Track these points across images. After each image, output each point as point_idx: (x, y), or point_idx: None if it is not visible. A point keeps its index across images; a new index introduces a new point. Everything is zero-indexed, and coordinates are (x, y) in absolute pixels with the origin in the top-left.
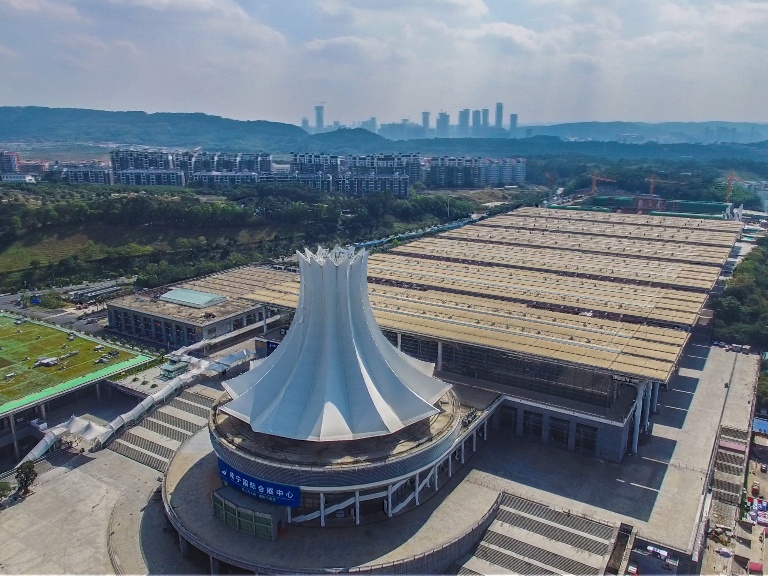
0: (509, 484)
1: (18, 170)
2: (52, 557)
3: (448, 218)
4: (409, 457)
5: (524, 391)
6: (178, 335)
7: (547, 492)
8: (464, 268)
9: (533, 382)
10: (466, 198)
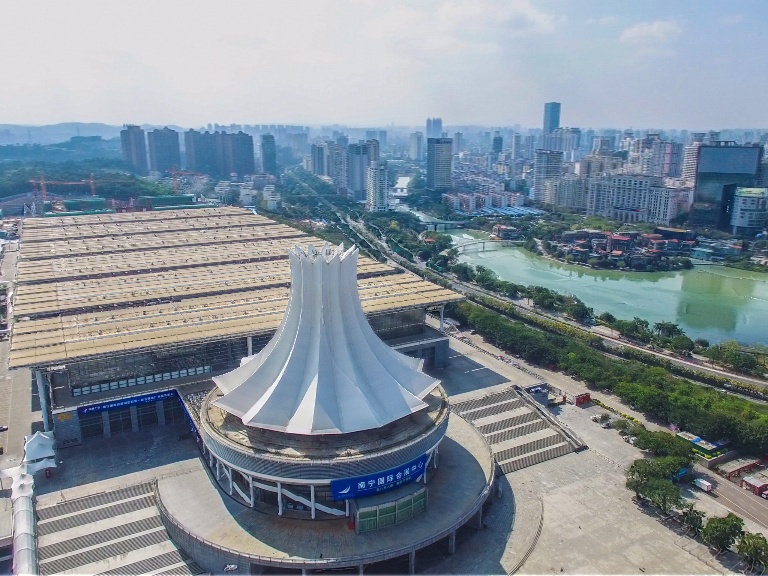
0: None
1: None
2: None
3: None
4: None
5: None
6: None
7: (459, 394)
8: (158, 276)
9: None
10: None
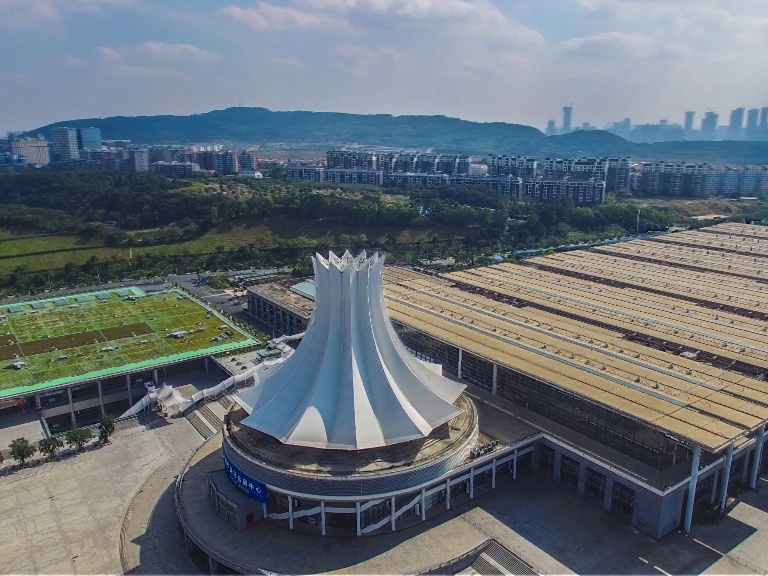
0: (505, 532)
1: (256, 167)
2: (89, 500)
3: (636, 230)
4: (375, 478)
5: (571, 432)
6: (291, 324)
7: (542, 551)
8: (586, 286)
9: (582, 424)
10: (676, 209)
